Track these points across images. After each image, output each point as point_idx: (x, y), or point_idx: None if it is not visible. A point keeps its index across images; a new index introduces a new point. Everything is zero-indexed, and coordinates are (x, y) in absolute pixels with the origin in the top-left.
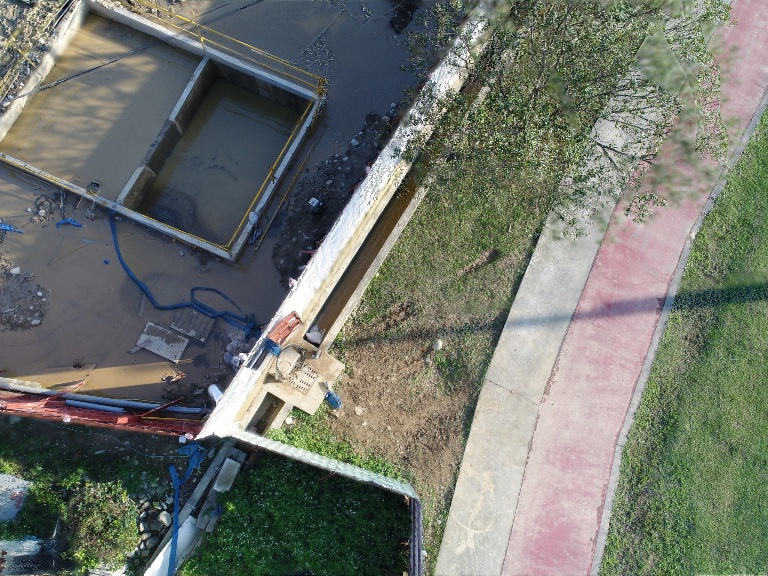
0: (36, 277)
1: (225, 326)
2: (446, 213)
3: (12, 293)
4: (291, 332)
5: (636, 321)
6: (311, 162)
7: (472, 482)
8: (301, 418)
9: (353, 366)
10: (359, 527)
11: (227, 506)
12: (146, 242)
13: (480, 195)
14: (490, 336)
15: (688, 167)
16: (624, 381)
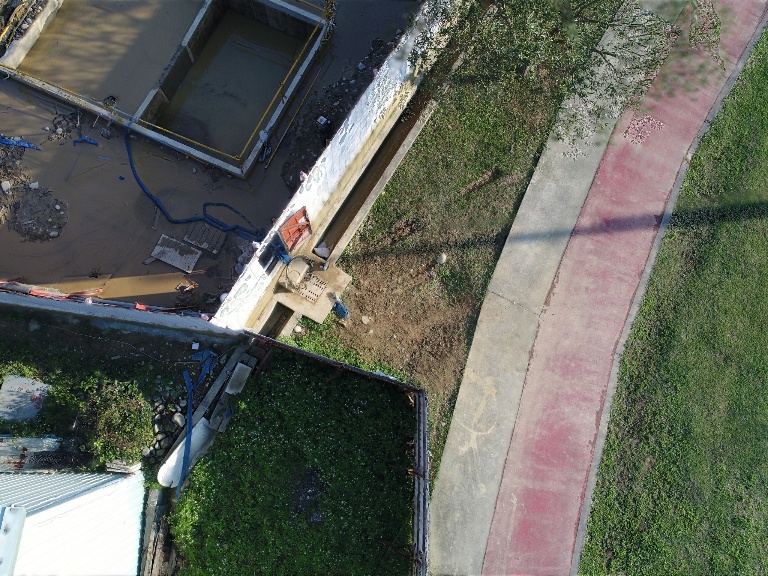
0: (54, 192)
1: (236, 239)
2: (450, 135)
3: (31, 206)
4: (300, 240)
5: (634, 237)
6: (319, 85)
7: (475, 387)
8: (310, 327)
9: (360, 278)
10: (366, 426)
11: (239, 405)
12: (159, 164)
13: (483, 118)
14: (492, 250)
15: (685, 92)
16: (622, 293)
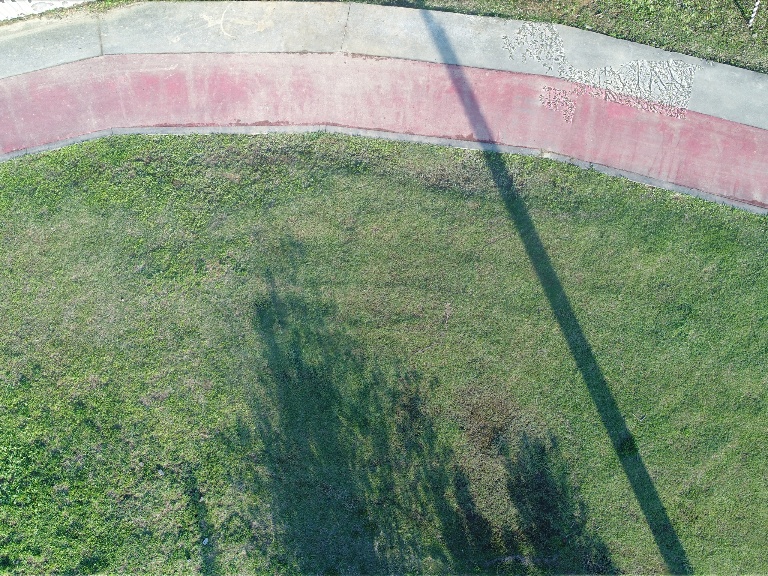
0: None
1: None
2: None
3: None
4: None
5: (444, 118)
6: None
7: (261, 13)
8: None
9: None
10: None
11: None
12: None
13: None
14: None
15: (615, 136)
16: (385, 119)
